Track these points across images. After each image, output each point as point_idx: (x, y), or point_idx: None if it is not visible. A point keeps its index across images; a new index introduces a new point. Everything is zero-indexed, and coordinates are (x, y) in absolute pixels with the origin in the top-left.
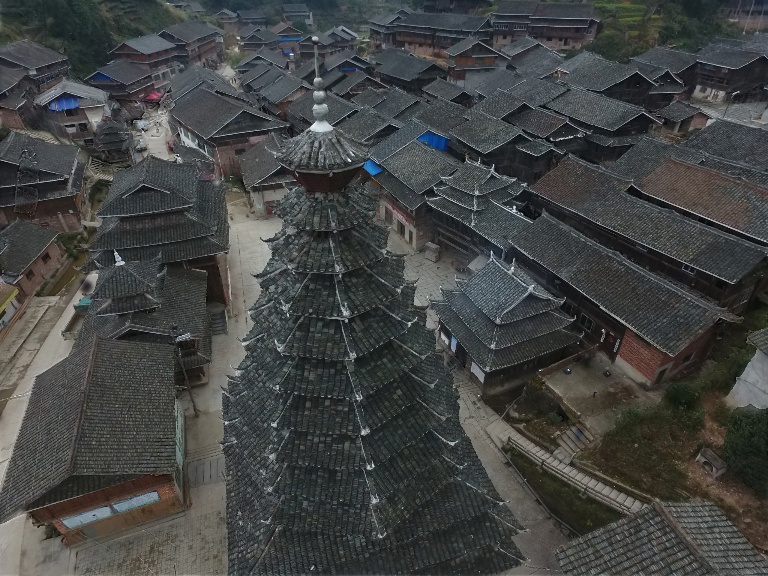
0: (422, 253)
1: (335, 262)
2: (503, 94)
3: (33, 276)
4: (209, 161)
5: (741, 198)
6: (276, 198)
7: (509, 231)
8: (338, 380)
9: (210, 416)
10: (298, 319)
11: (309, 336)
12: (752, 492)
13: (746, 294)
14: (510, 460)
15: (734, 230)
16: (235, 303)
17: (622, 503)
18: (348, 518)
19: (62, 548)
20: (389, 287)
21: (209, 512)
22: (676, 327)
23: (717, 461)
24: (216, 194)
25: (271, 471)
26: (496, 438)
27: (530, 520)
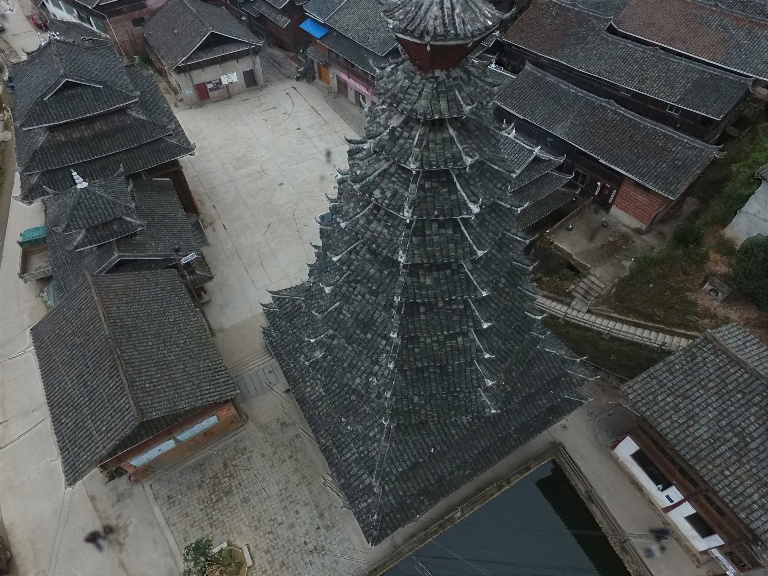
0: None
1: (463, 153)
2: None
3: None
4: (102, 38)
5: (718, 27)
6: (206, 79)
7: None
8: (457, 280)
9: (227, 332)
10: (411, 223)
11: (427, 240)
12: (751, 307)
13: (721, 129)
14: None
15: (712, 63)
16: (204, 210)
17: (644, 336)
18: (459, 402)
19: (132, 485)
20: (504, 173)
21: (268, 421)
22: (675, 171)
23: (724, 287)
24: None
25: (382, 377)
26: None
27: None
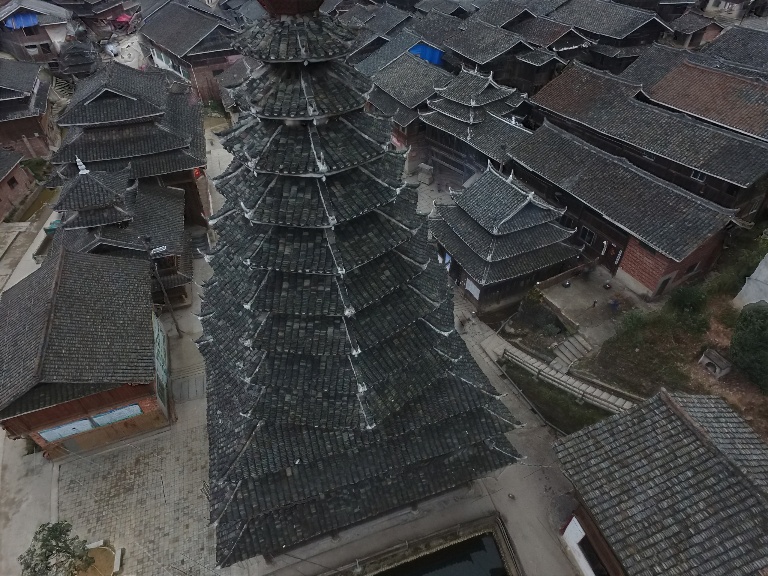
0: (415, 176)
1: (308, 104)
2: (503, 1)
3: None
4: (185, 83)
5: (758, 101)
6: None
7: (507, 144)
8: (317, 254)
9: (194, 337)
10: (269, 183)
11: (282, 202)
12: (756, 390)
13: (756, 203)
14: (505, 372)
15: (748, 135)
16: None
17: (621, 406)
18: (334, 411)
19: (44, 462)
20: (373, 143)
21: (195, 426)
22: (683, 232)
23: (722, 361)
24: (191, 109)
25: (249, 363)
26: (491, 352)
27: (525, 428)
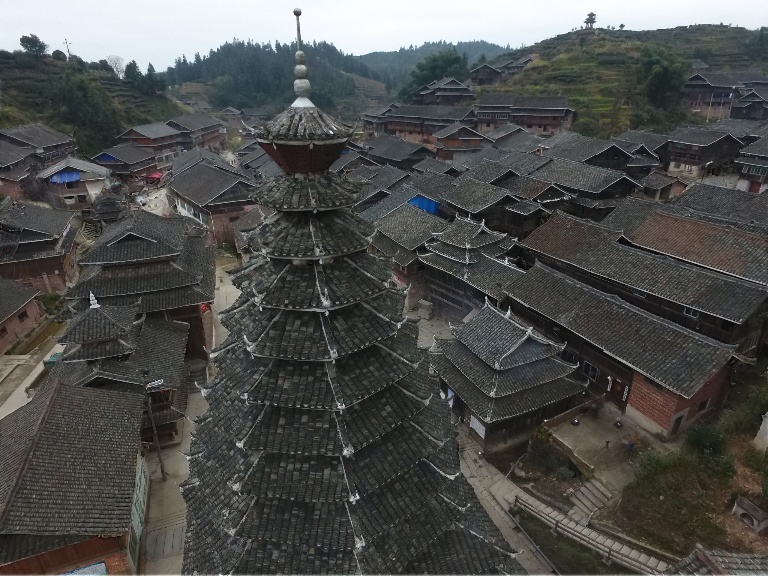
0: (415, 312)
1: (315, 245)
2: (489, 163)
3: (6, 334)
4: (203, 228)
5: (732, 245)
6: None
7: (503, 282)
8: (317, 388)
9: (179, 479)
10: (273, 317)
11: (285, 335)
12: None
13: (754, 339)
14: (519, 524)
15: (731, 275)
16: None
17: None
18: (327, 571)
19: None
20: (375, 281)
21: None
22: (687, 367)
23: (757, 511)
24: (206, 250)
25: (235, 510)
26: (502, 499)
27: None
